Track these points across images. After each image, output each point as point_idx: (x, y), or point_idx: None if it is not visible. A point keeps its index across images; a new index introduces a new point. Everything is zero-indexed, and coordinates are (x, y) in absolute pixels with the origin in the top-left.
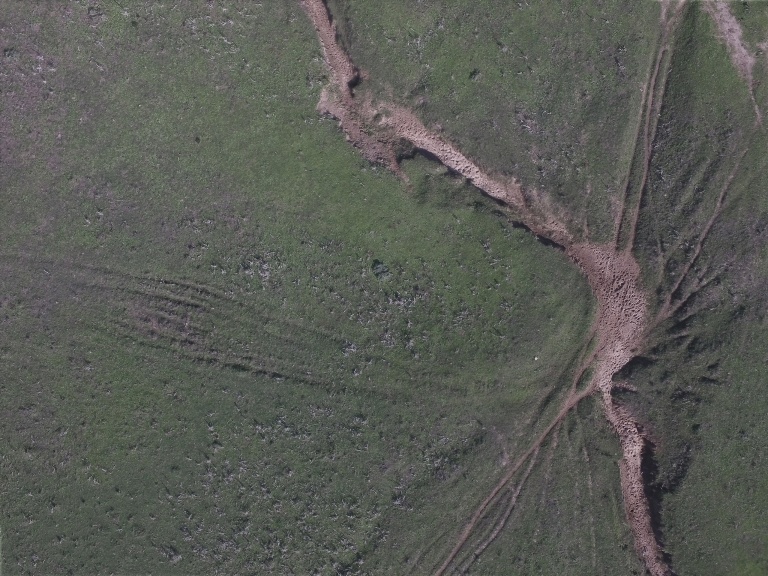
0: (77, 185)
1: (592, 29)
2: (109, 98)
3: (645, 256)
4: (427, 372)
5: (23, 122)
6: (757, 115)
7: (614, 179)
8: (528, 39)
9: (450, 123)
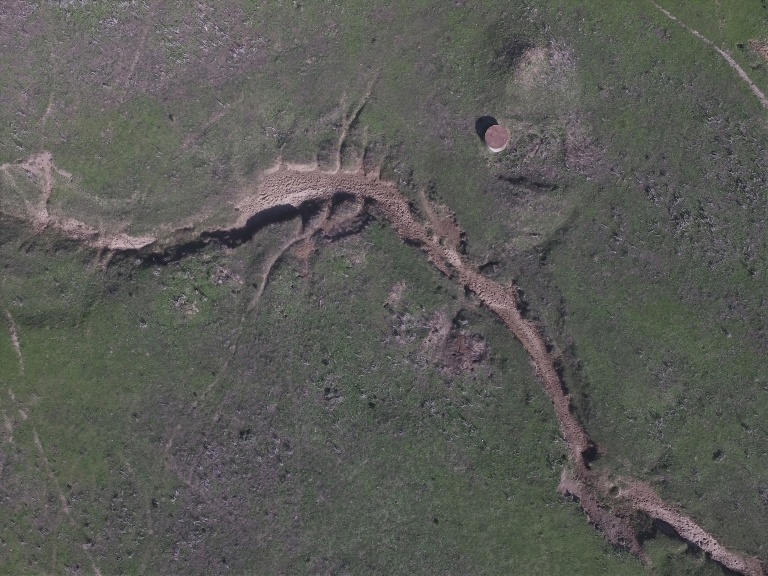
0: (314, 567)
1: None
2: (346, 480)
3: None
4: None
5: (260, 504)
6: None
7: None
8: None
9: (693, 504)
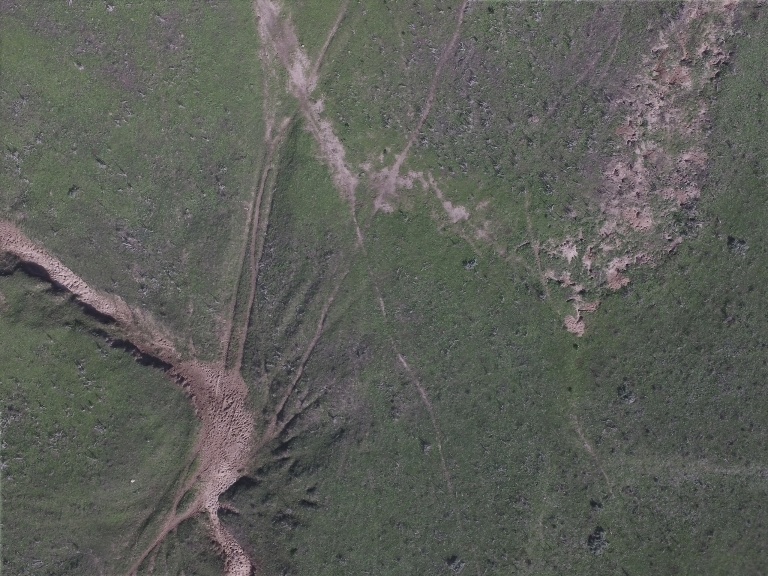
0: None
1: (192, 147)
2: None
3: (251, 376)
4: (22, 494)
5: None
6: (358, 237)
7: (216, 299)
8: (128, 156)
9: (49, 240)
